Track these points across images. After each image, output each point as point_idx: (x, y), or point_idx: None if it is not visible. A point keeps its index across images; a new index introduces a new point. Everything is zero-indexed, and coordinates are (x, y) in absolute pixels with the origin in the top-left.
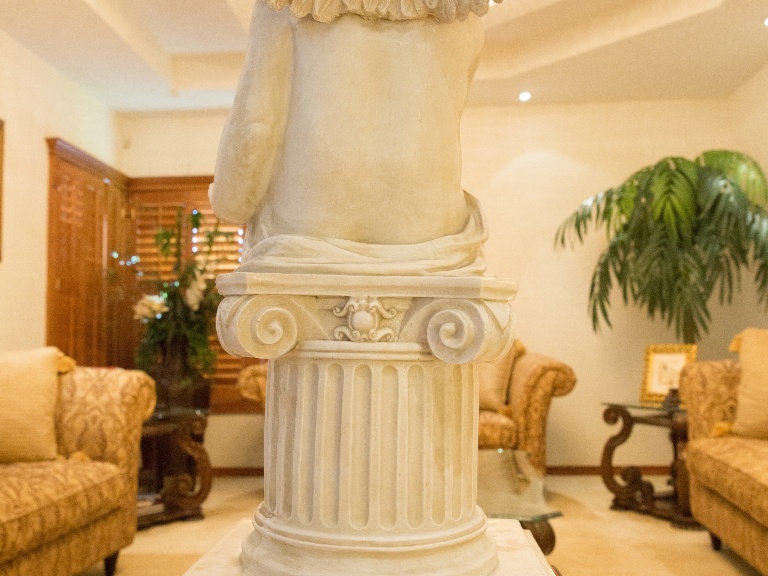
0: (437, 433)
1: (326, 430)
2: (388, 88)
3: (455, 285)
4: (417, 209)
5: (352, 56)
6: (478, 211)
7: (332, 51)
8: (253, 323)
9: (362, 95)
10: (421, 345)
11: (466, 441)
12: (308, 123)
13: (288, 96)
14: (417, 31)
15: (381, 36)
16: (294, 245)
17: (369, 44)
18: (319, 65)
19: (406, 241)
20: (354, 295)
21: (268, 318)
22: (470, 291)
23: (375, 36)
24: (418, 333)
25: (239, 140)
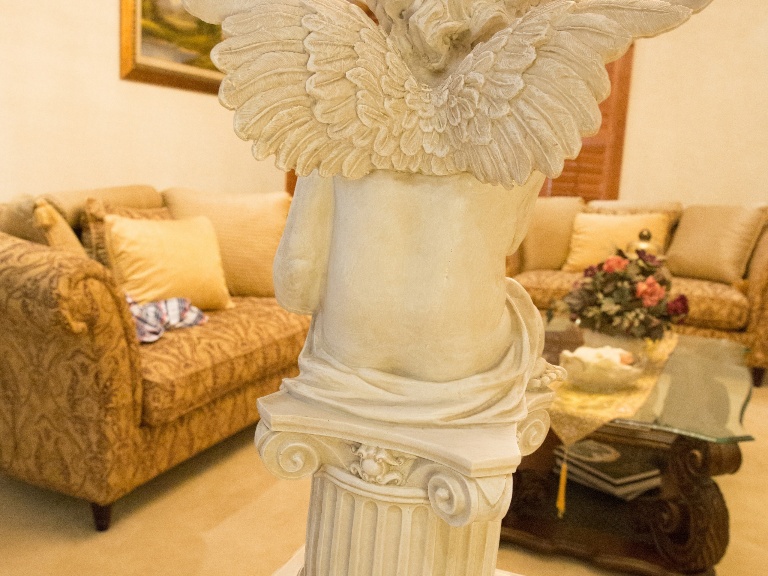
0: (439, 562)
1: (340, 545)
2: (418, 243)
3: (451, 459)
4: (444, 353)
5: (382, 212)
6: (521, 341)
7: (364, 205)
8: (278, 454)
9: (391, 250)
10: (426, 492)
11: (473, 565)
12: (340, 270)
13: (330, 233)
14: (451, 186)
15: (414, 190)
16: (325, 377)
17: (400, 199)
18: (352, 217)
19: (434, 378)
20: (365, 443)
21: (291, 450)
22: (463, 468)
23: (407, 190)
24: (423, 482)
25: (285, 271)
